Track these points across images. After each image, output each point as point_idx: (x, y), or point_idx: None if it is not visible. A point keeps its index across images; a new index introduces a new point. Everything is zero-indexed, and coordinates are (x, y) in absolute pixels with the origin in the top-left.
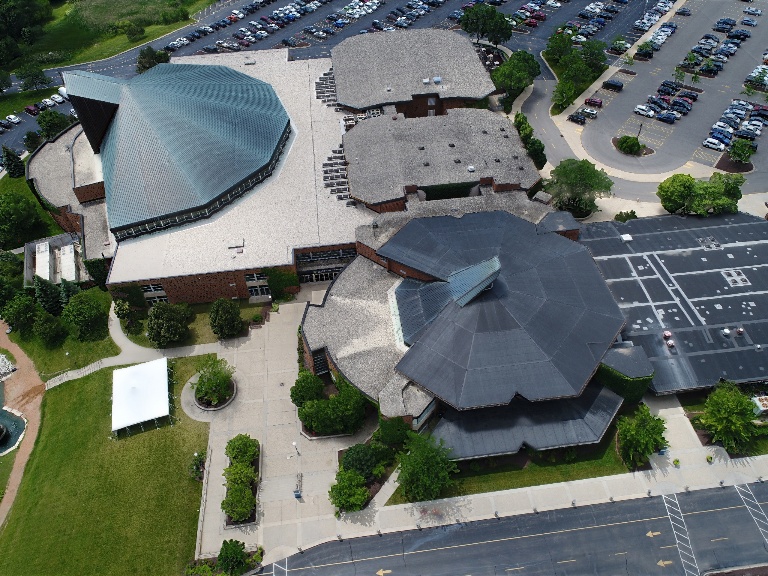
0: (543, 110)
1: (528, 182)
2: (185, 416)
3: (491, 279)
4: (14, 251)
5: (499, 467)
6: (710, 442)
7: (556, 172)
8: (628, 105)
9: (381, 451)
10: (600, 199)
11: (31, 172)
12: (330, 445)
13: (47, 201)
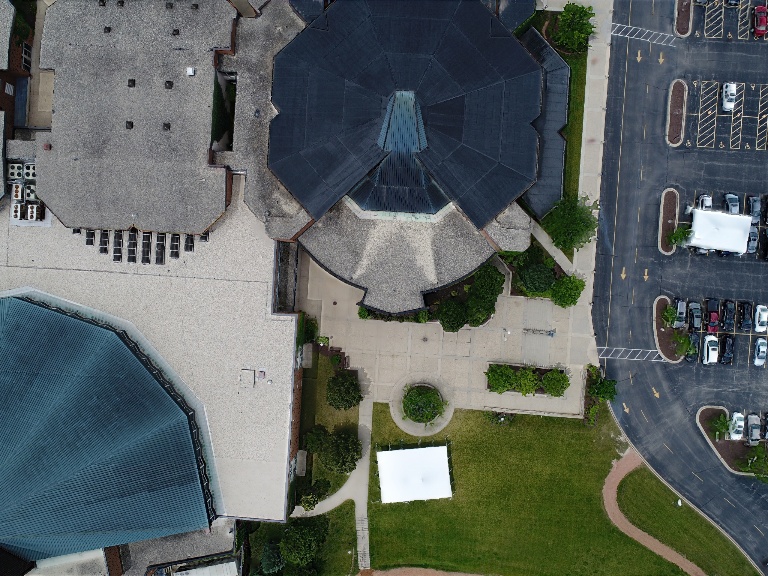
0: None
1: (224, 8)
2: (443, 432)
3: (418, 107)
4: None
5: None
6: None
7: None
8: None
9: (529, 258)
10: None
11: None
12: (501, 302)
13: None
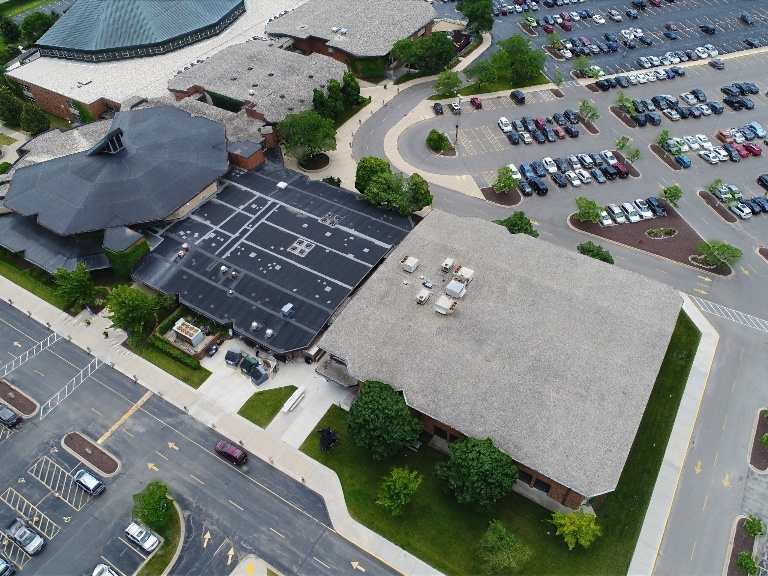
0: (428, 93)
1: (278, 119)
2: None
3: (103, 141)
4: None
5: (13, 262)
6: (126, 328)
7: None
8: (504, 116)
9: None
10: (346, 166)
11: None
12: None
13: None
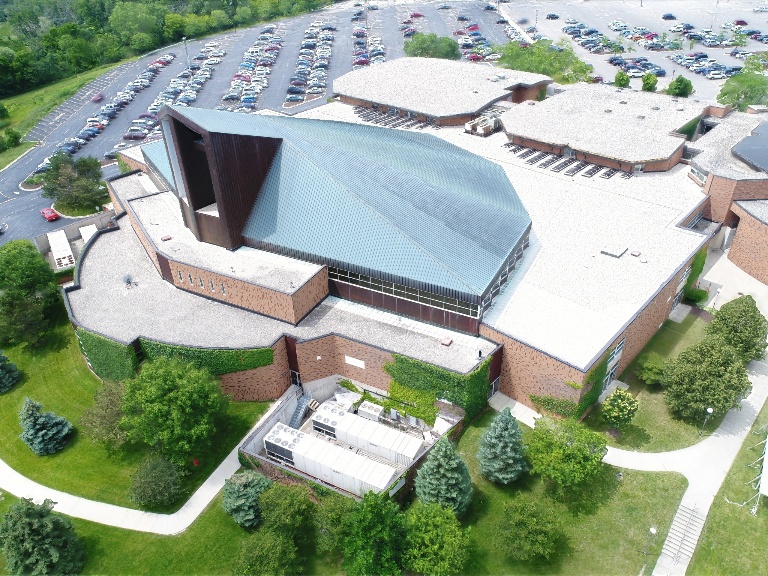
0: None
1: None
2: None
3: None
4: (211, 483)
5: None
6: None
7: (744, 86)
8: None
9: None
10: None
11: (110, 336)
12: None
13: (234, 348)
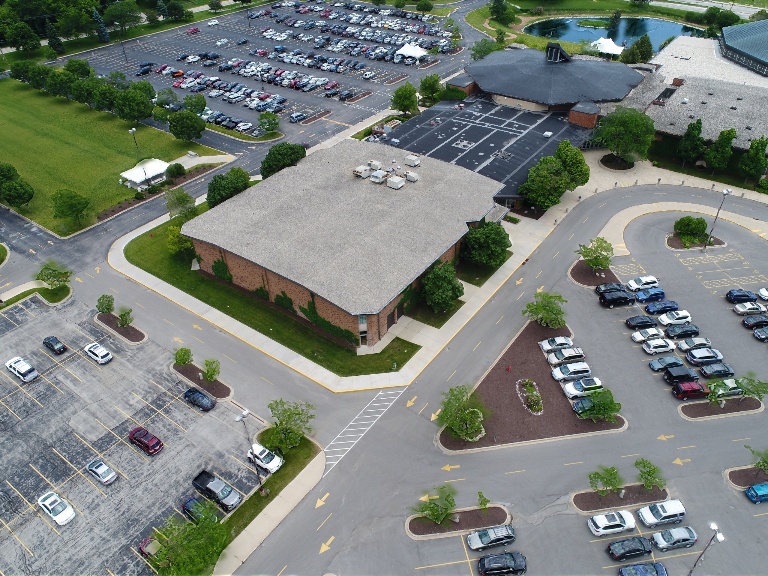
0: None
1: None
2: None
3: None
4: None
5: None
6: (404, 114)
7: None
8: None
9: None
10: (619, 180)
11: None
12: None
13: None
